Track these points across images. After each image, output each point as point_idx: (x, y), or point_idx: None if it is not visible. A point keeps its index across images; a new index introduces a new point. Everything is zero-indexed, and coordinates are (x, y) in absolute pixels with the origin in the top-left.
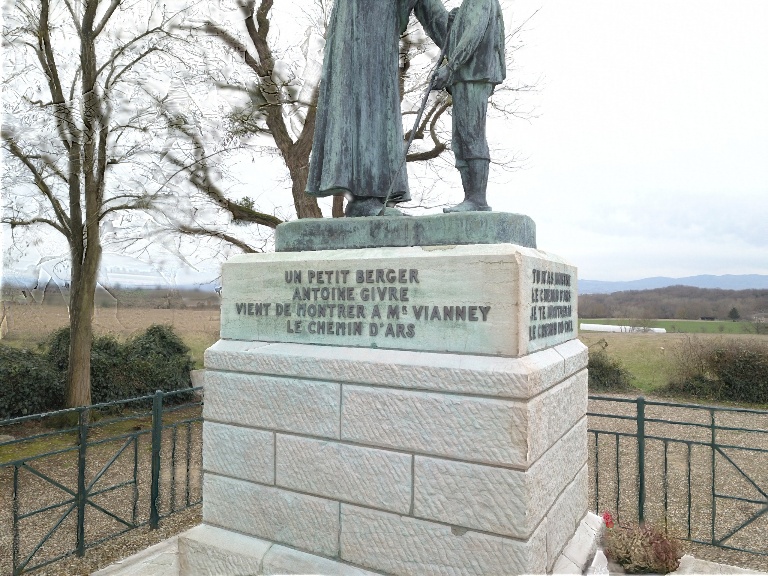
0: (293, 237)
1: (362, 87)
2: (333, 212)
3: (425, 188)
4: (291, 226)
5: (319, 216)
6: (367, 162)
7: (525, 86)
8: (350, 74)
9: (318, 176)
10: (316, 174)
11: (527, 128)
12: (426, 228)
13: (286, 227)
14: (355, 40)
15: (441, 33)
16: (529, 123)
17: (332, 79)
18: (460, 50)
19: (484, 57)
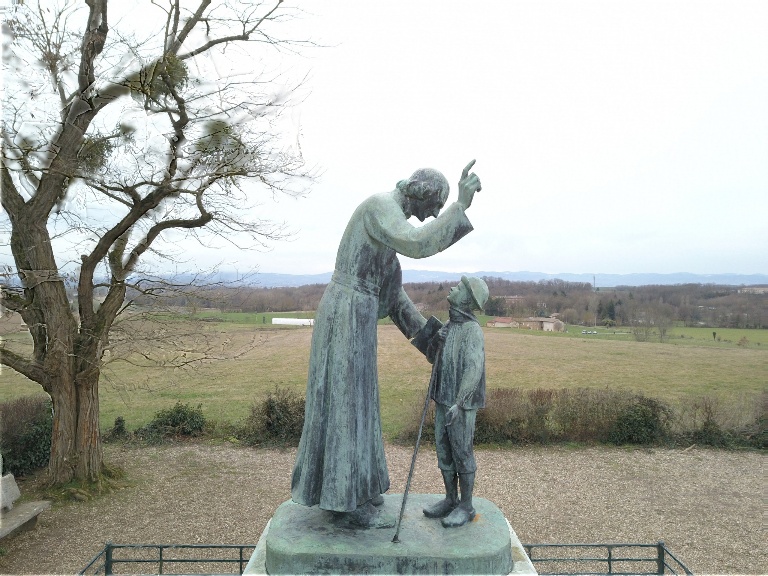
0: (304, 569)
1: (359, 398)
2: (80, 285)
3: (201, 271)
4: (301, 557)
5: (62, 290)
6: (363, 471)
7: (302, 175)
8: (354, 392)
9: (315, 489)
10: (312, 487)
11: (293, 203)
12: (456, 567)
13: (294, 558)
14: (354, 354)
15: (407, 322)
16: (295, 199)
17: (333, 394)
18: (469, 391)
19: (480, 388)
